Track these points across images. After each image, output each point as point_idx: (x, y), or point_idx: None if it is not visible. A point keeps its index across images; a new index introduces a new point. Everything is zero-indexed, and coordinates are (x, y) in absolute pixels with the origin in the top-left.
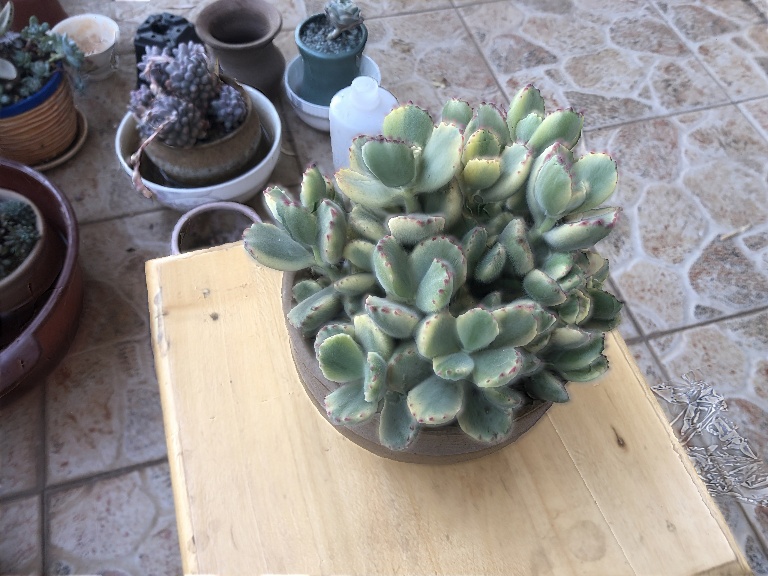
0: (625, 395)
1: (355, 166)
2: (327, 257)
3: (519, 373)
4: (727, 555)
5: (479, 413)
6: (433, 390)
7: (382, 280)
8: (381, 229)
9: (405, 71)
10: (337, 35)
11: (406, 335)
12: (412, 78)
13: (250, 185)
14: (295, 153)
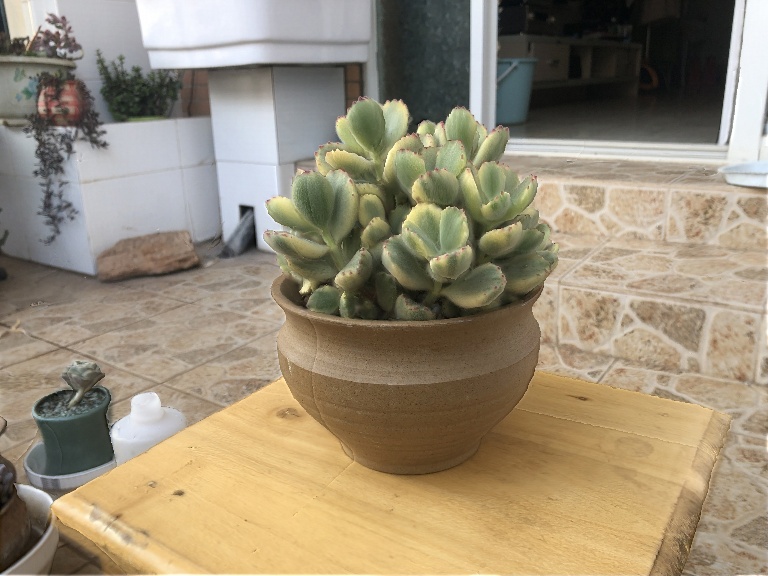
0: (554, 382)
1: (326, 168)
2: (353, 205)
3: None
4: (708, 411)
5: (522, 271)
6: None
7: (415, 172)
8: (375, 185)
9: None
10: (80, 397)
11: (456, 194)
12: None
13: (40, 564)
14: (63, 542)
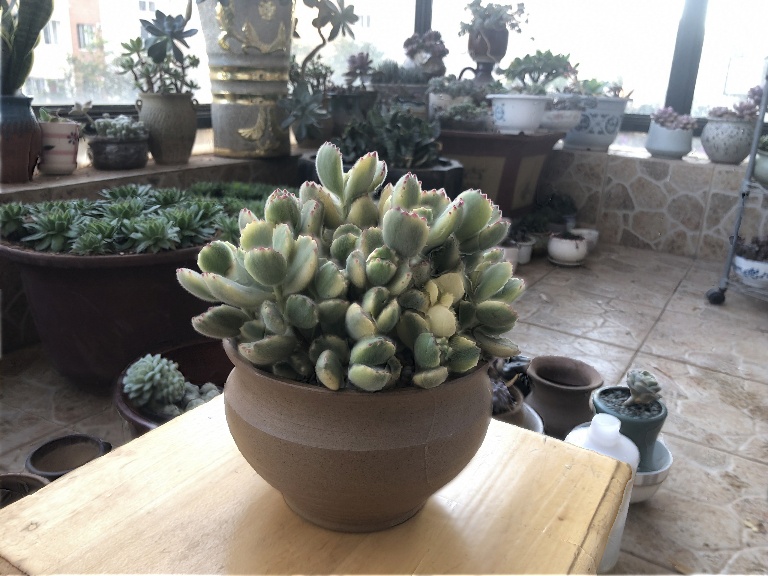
0: None
1: None
2: None
3: (296, 311)
4: None
5: None
6: (236, 283)
7: None
8: None
9: (720, 498)
10: (631, 402)
11: None
12: (723, 506)
13: None
14: None
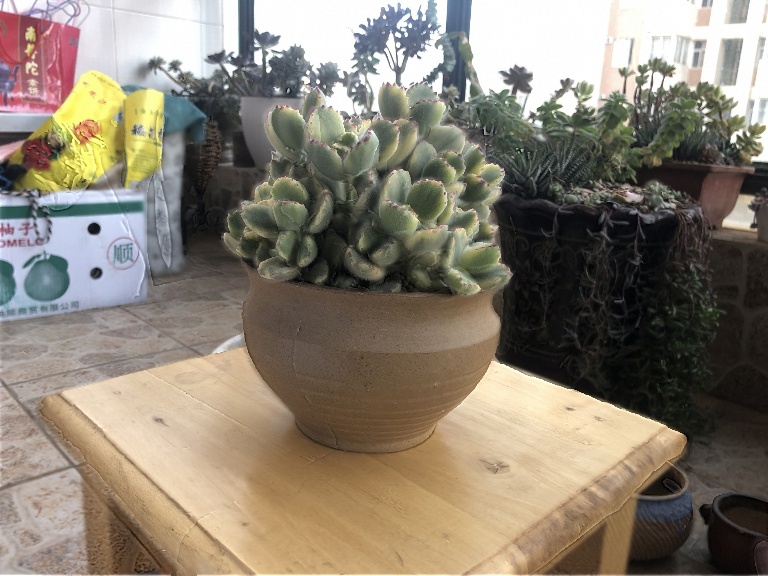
0: None
1: None
2: None
3: None
4: None
5: None
6: None
7: None
8: None
9: None
10: None
11: None
12: None
13: None
14: None
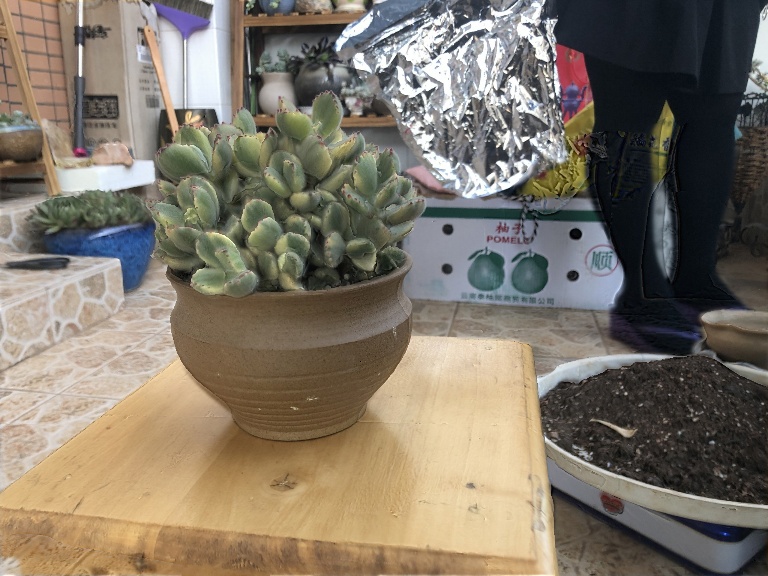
0: None
1: None
2: None
3: None
4: None
5: None
6: None
7: None
8: None
9: None
10: None
11: None
12: None
13: None
14: None
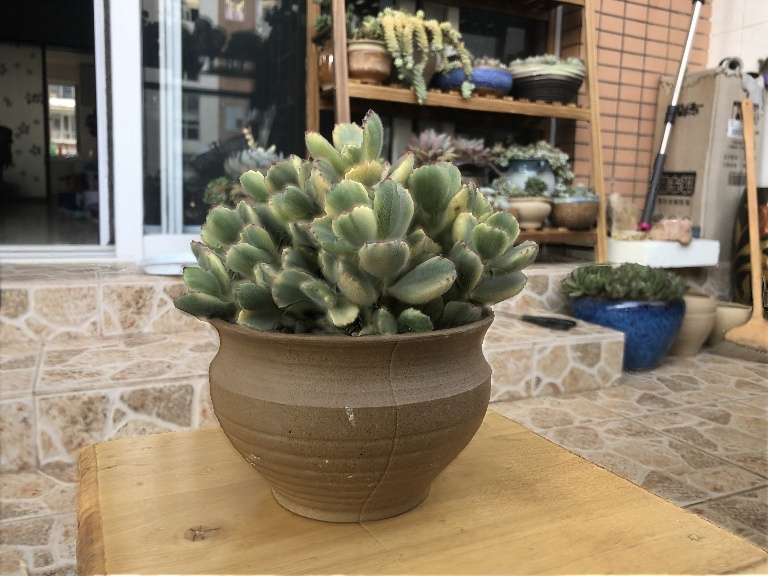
0: None
1: (330, 186)
2: None
3: None
4: None
5: None
6: None
7: (445, 185)
8: None
9: None
10: None
11: None
12: None
13: None
14: None
